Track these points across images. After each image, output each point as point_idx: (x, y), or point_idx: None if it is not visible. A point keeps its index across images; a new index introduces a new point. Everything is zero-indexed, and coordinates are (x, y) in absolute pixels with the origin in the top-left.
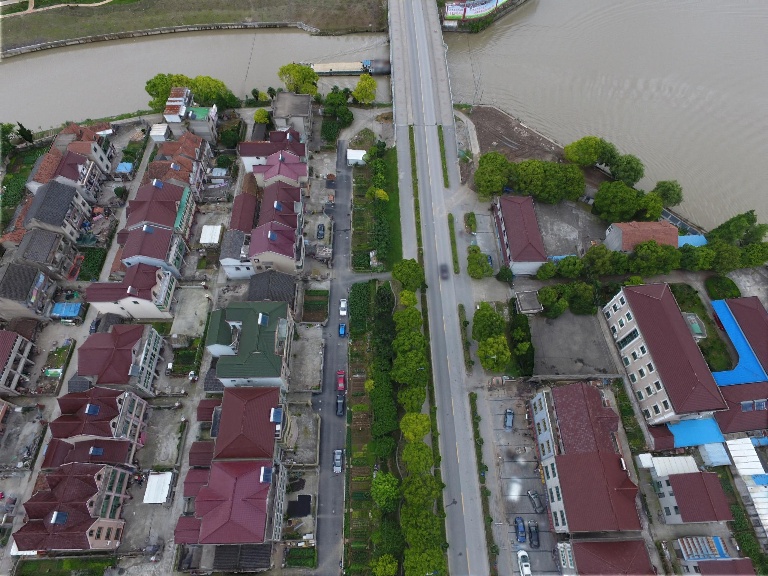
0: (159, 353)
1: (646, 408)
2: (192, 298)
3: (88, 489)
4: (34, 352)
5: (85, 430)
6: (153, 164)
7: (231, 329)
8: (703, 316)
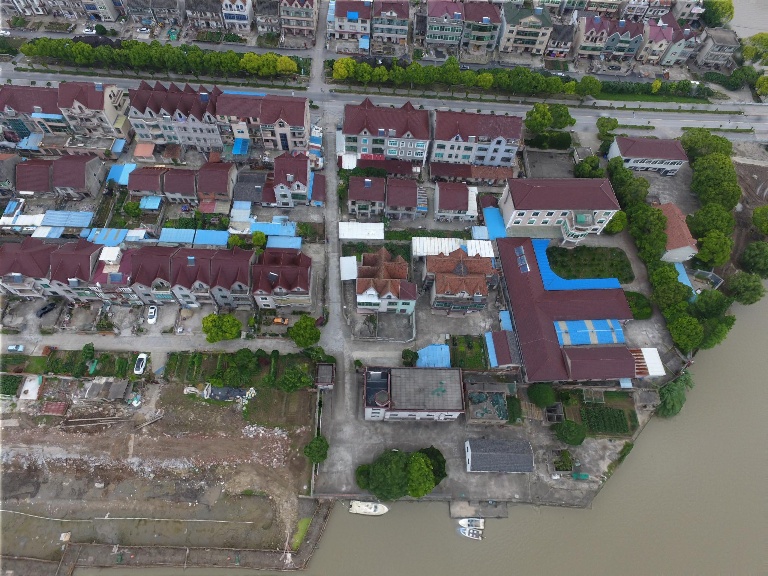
0: None
1: None
2: None
3: None
4: None
5: None
6: None
7: None
8: None
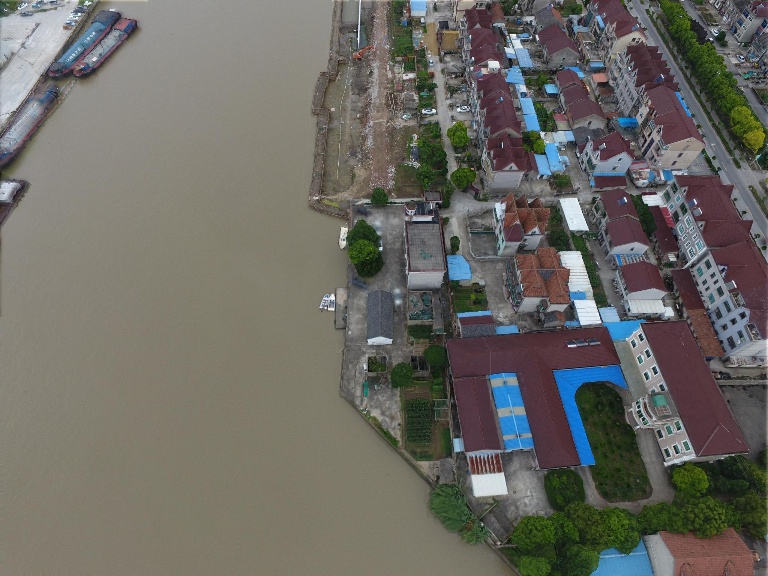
0: None
1: None
2: None
3: None
4: None
5: None
6: None
7: None
8: (595, 452)
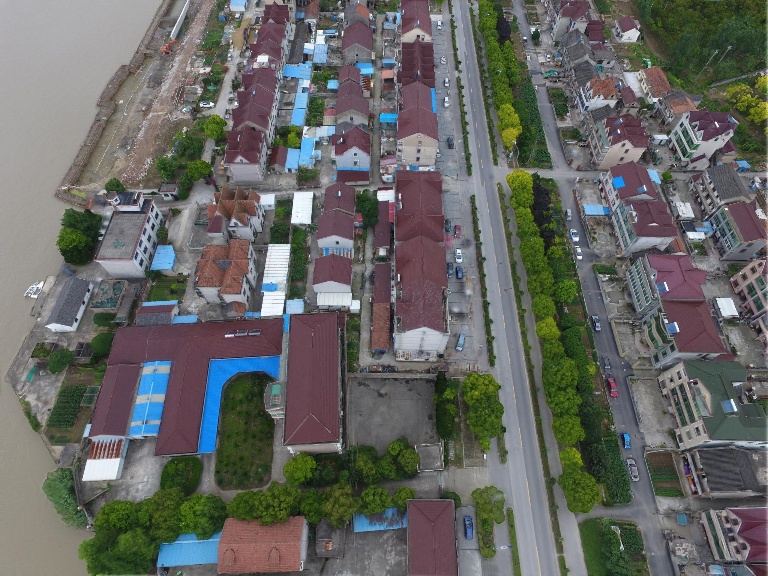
0: None
1: None
2: None
3: None
4: None
5: None
6: None
7: None
8: (227, 440)
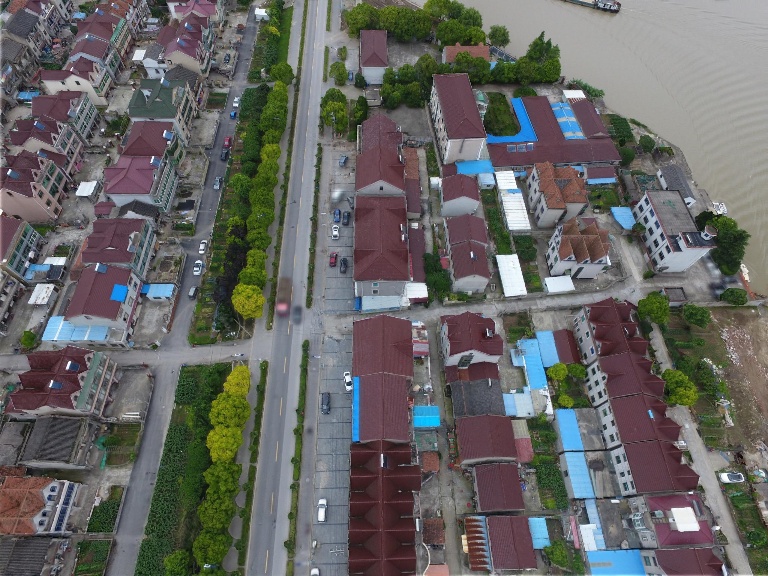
0: (94, 120)
1: (443, 154)
2: (124, 95)
3: (34, 167)
4: (4, 120)
5: (33, 135)
6: (98, 4)
7: (146, 101)
8: None
